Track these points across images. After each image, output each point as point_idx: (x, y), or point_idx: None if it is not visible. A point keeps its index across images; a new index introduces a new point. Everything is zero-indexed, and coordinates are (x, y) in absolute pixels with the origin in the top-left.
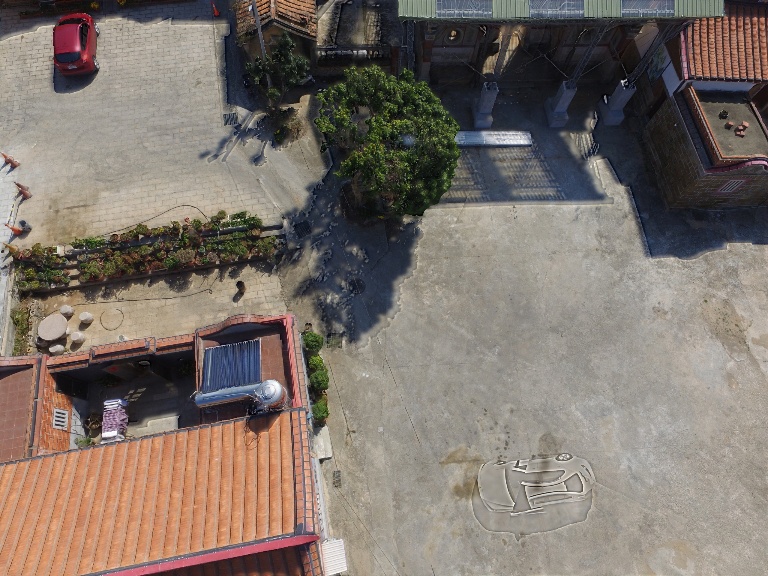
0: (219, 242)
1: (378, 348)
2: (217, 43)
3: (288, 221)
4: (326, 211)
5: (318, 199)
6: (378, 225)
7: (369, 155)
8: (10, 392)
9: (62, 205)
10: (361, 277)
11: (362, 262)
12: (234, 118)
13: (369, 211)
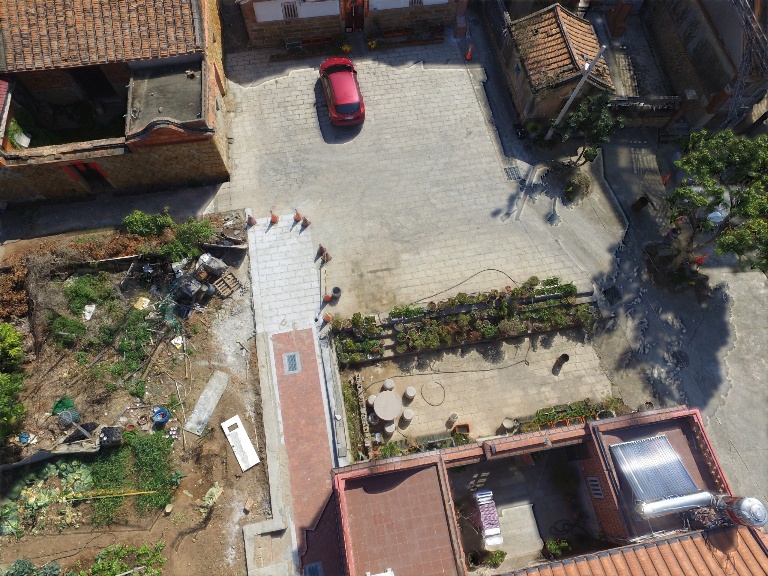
0: (534, 310)
1: (719, 429)
2: (476, 89)
3: (597, 287)
4: (633, 276)
5: (622, 262)
6: (688, 291)
7: (766, 235)
8: (420, 494)
9: (365, 268)
10: (682, 349)
11: (680, 332)
12: (516, 172)
13: (682, 277)
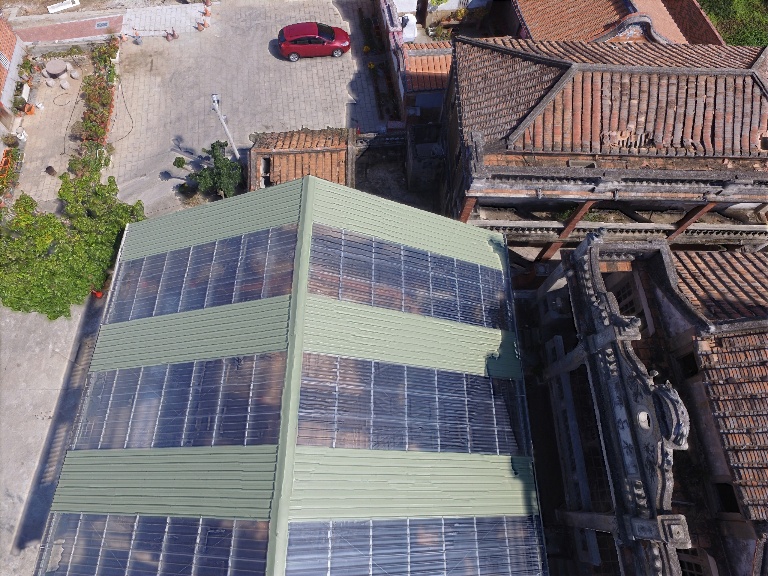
0: None
1: None
2: None
3: None
4: None
5: None
6: None
7: (4, 208)
8: None
9: (156, 58)
10: None
11: None
12: None
13: None
